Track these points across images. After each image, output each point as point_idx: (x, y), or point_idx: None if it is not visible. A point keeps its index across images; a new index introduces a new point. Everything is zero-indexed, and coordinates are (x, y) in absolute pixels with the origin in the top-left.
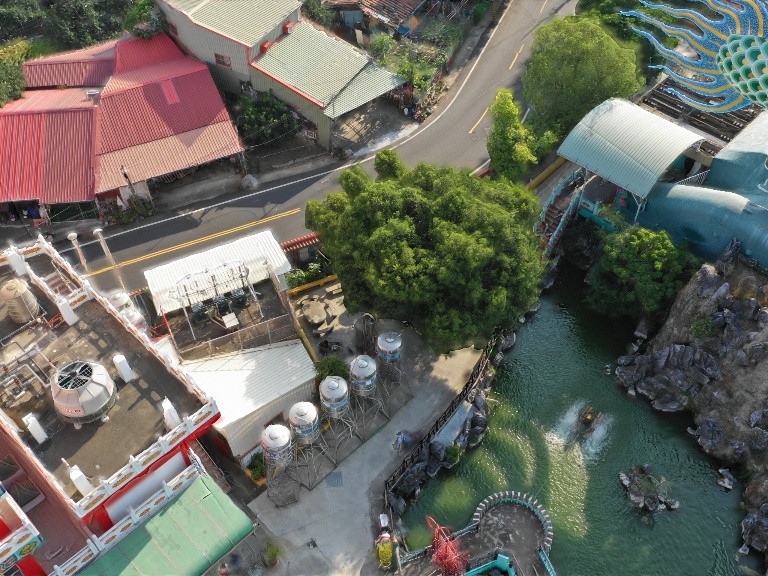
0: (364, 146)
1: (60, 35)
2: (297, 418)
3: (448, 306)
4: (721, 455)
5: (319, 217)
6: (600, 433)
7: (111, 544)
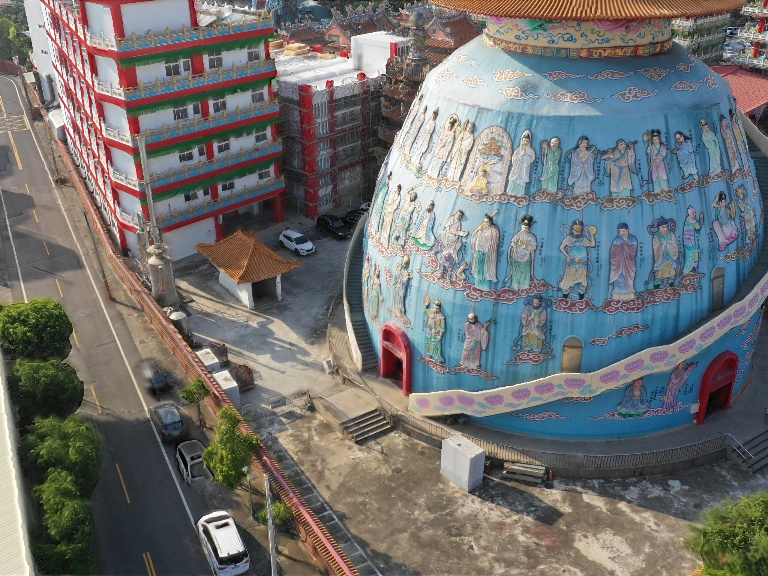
0: None
1: None
2: None
3: None
4: None
5: None
6: None
7: None
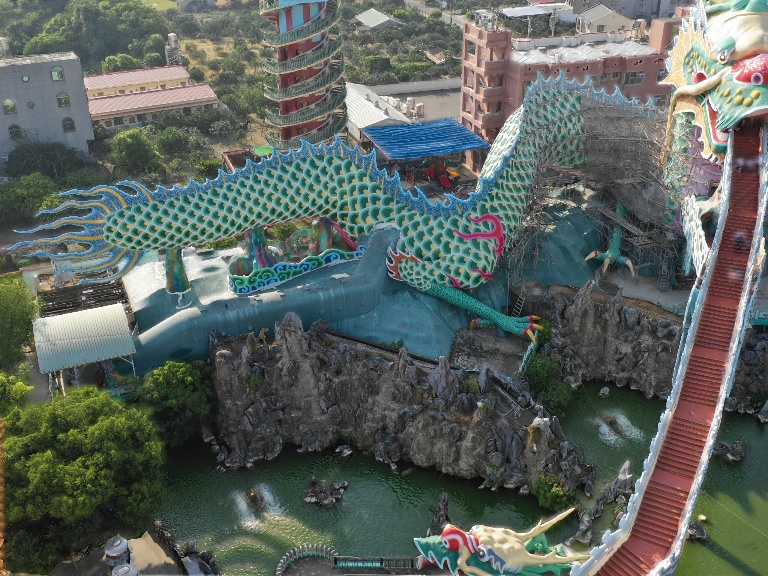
0: None
1: None
2: None
3: (127, 487)
4: (329, 443)
5: None
6: (268, 496)
7: None
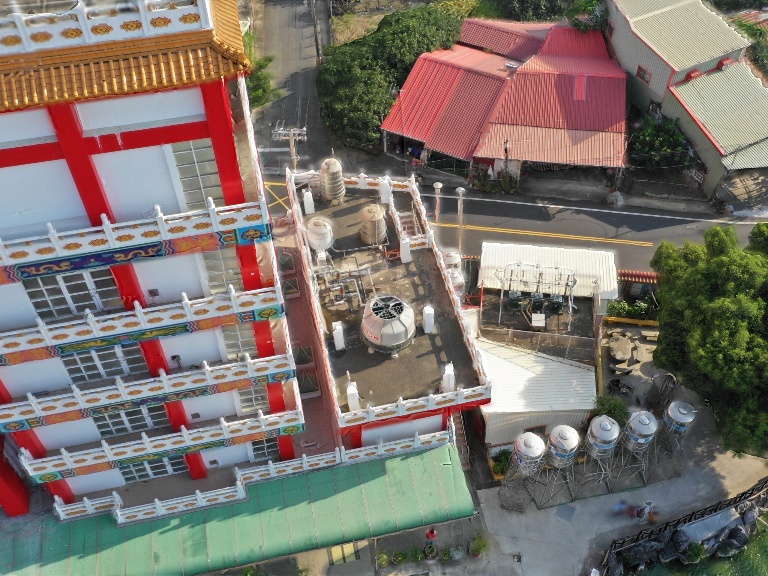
0: (749, 208)
1: (507, 3)
2: (557, 438)
3: (761, 407)
4: None
5: (668, 261)
6: None
7: (353, 461)
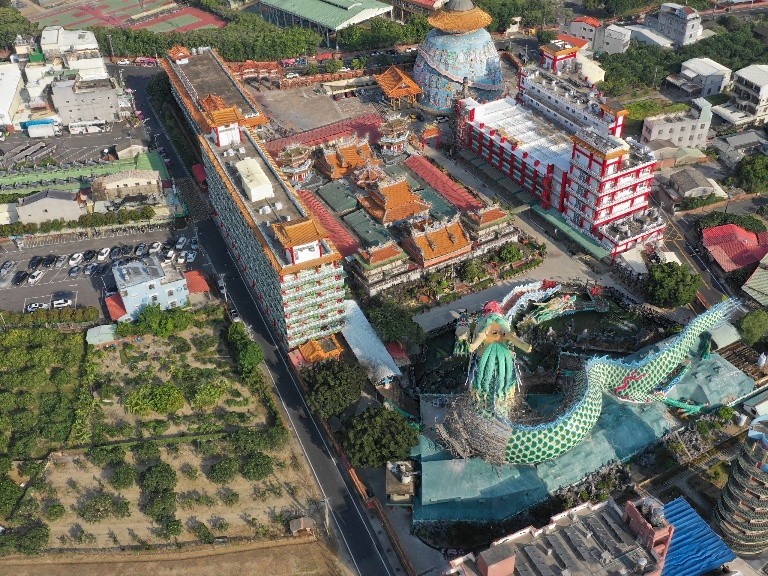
0: None
1: None
2: None
3: None
4: None
5: None
6: (626, 328)
7: None
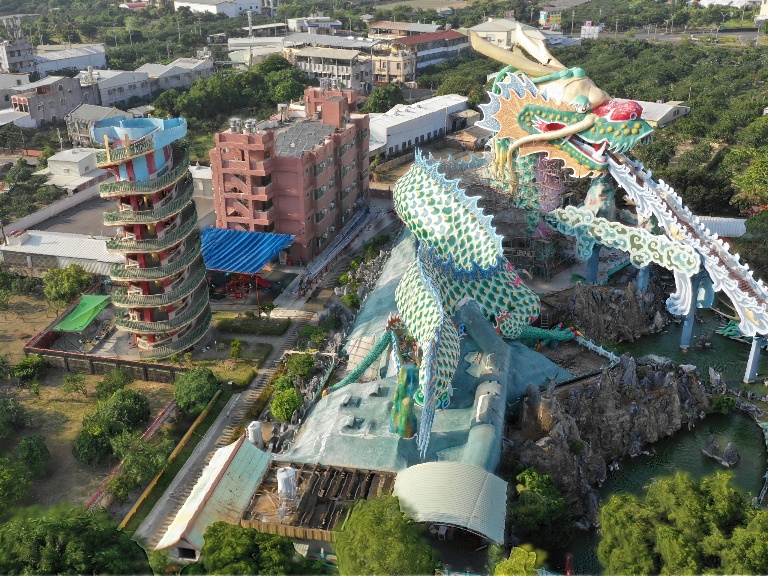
0: None
1: None
2: None
3: None
4: None
5: None
6: None
7: None
